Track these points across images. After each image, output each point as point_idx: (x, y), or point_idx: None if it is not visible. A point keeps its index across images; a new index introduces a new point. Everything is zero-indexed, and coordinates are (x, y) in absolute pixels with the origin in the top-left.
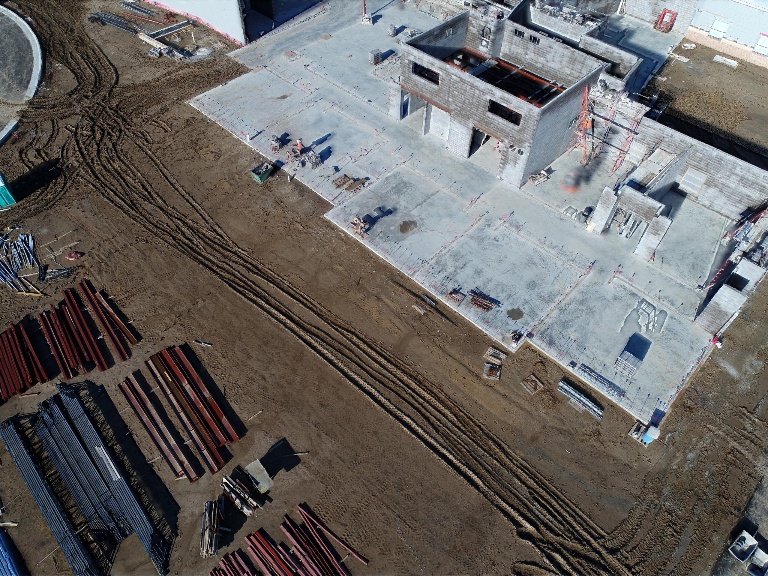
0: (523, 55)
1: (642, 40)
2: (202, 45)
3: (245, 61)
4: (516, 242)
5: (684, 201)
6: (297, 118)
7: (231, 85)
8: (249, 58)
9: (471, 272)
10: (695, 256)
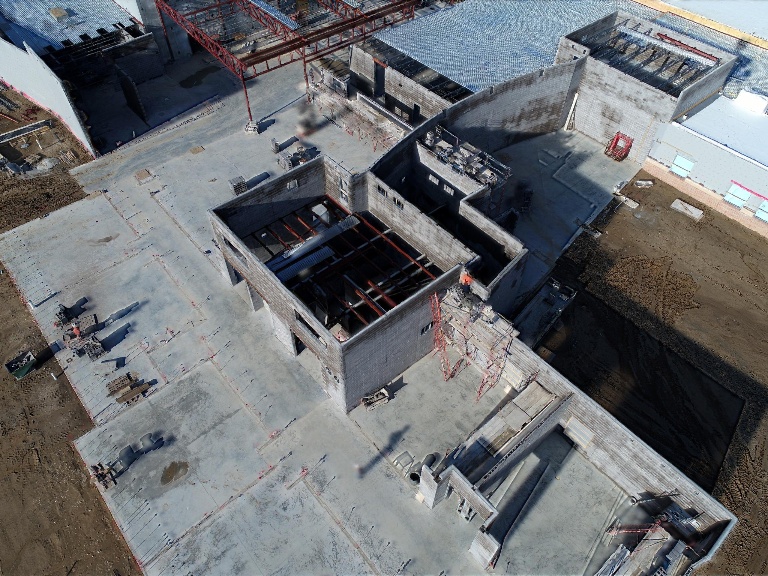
0: (390, 216)
1: (585, 171)
2: (48, 155)
3: (85, 182)
4: (310, 514)
5: (569, 453)
6: (108, 274)
7: (52, 218)
8: (92, 178)
9: (227, 568)
10: (557, 563)
